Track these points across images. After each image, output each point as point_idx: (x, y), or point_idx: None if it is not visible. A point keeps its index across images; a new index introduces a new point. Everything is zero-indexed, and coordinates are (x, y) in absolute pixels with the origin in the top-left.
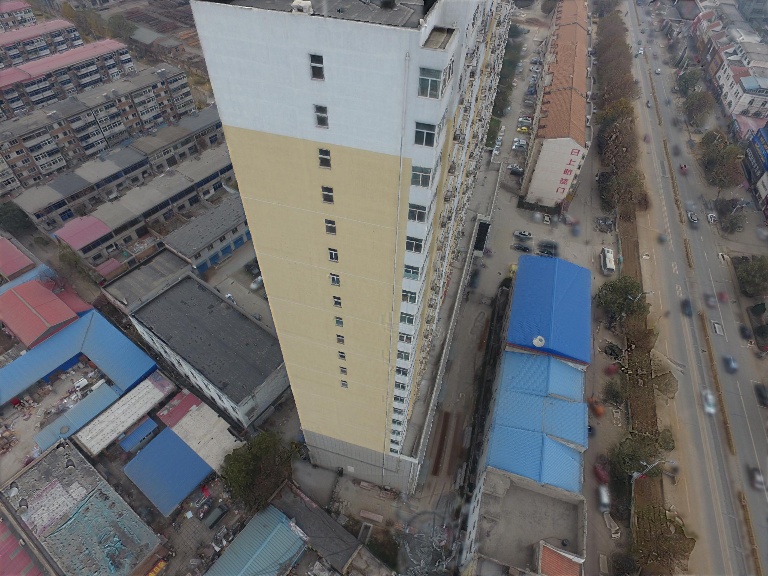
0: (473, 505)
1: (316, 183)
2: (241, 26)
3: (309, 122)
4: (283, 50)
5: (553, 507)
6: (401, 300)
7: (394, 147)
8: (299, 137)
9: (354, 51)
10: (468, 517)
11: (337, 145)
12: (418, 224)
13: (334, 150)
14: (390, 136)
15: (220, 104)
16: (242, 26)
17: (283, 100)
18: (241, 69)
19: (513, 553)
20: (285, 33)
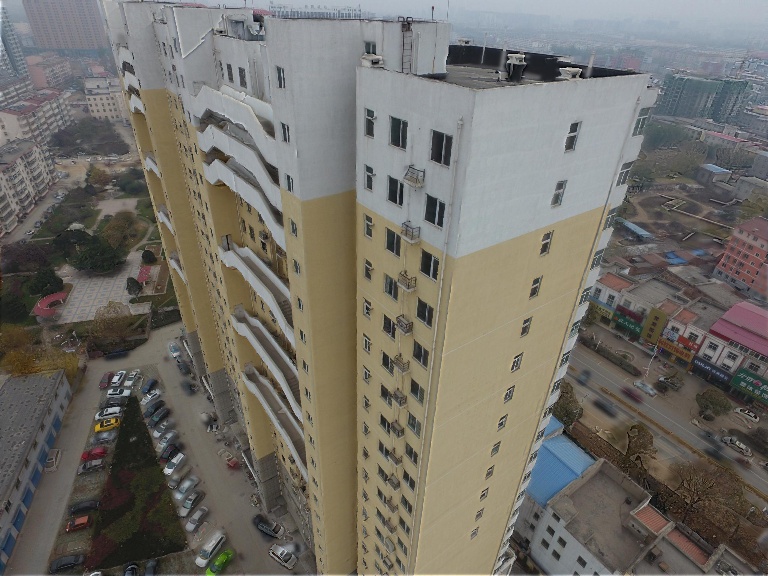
0: (548, 554)
1: (530, 279)
2: (523, 109)
3: (546, 206)
4: (553, 126)
5: (596, 487)
6: (558, 368)
7: (603, 198)
8: (533, 229)
9: (606, 108)
10: (547, 571)
11: (563, 220)
12: (597, 270)
13: (560, 227)
14: (604, 187)
15: (463, 229)
16: (524, 109)
17: (532, 190)
18: (503, 168)
19: (624, 546)
20: (560, 105)
